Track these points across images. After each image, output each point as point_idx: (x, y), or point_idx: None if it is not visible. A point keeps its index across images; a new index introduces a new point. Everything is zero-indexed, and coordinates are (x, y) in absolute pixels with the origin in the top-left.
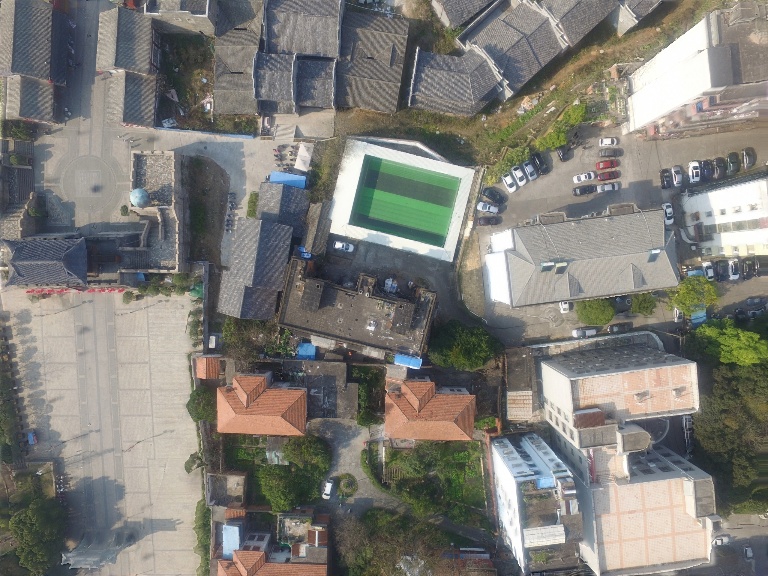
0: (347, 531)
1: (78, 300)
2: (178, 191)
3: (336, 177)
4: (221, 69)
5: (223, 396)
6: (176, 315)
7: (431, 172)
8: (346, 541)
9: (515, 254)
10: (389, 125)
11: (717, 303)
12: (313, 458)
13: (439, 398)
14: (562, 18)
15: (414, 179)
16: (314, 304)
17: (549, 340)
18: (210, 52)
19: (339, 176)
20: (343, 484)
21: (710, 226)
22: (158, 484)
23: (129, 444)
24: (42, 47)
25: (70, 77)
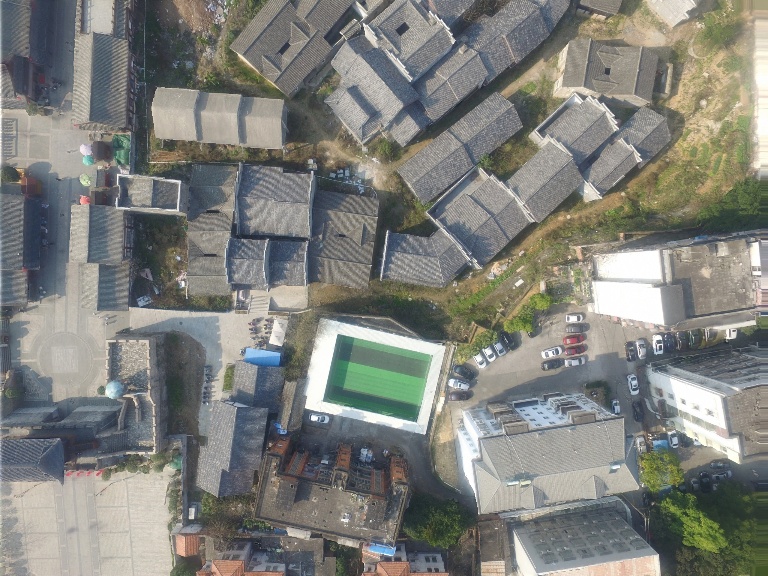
0: None
1: None
2: (154, 375)
3: (310, 352)
4: (194, 252)
5: None
6: (155, 486)
7: None
8: None
9: (482, 466)
10: (362, 294)
11: (682, 467)
12: None
13: None
14: (528, 200)
15: (387, 351)
16: (289, 503)
17: None
18: (183, 231)
19: (313, 354)
20: None
21: (672, 407)
22: None
23: None
24: (14, 239)
25: (44, 257)
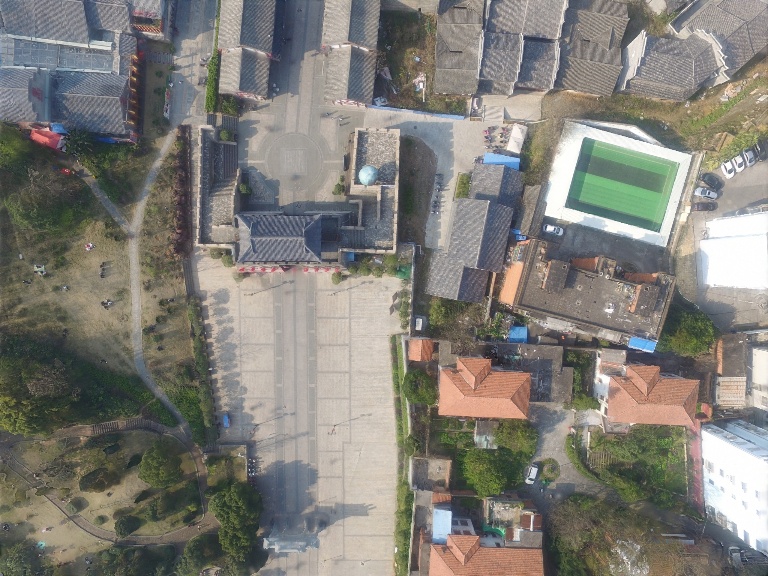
0: (563, 515)
1: (278, 280)
2: None
3: (549, 160)
4: (441, 47)
5: (448, 378)
6: (379, 297)
7: (644, 157)
8: (565, 525)
9: None
10: (596, 109)
11: None
12: (528, 442)
13: (664, 382)
14: None
15: (626, 163)
16: (560, 285)
17: (758, 327)
18: (424, 30)
19: (556, 159)
20: (547, 469)
21: None
22: (352, 468)
23: (324, 427)
24: (266, 20)
25: None
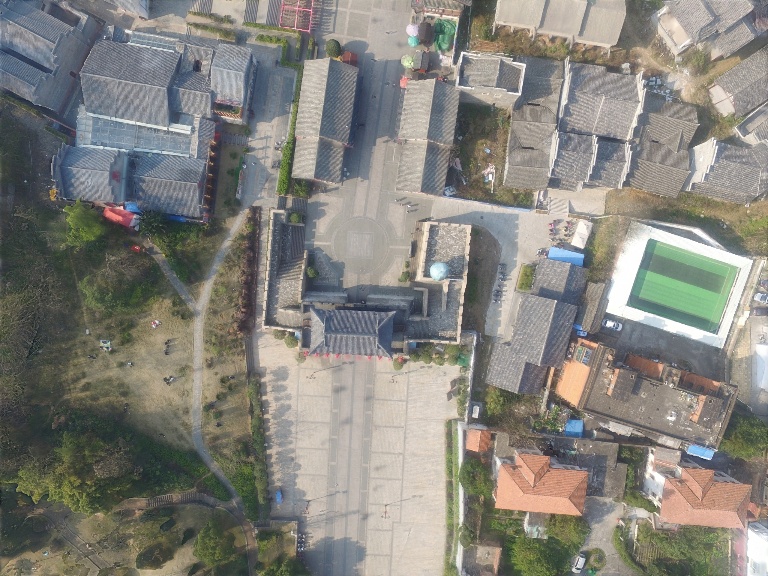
0: None
1: (338, 360)
2: None
3: (612, 257)
4: (514, 143)
5: (508, 474)
6: (437, 382)
7: (705, 258)
8: None
9: None
10: (658, 206)
11: None
12: None
13: (718, 486)
14: None
15: (686, 263)
16: (626, 394)
17: None
18: (496, 123)
19: (620, 257)
20: (594, 559)
21: None
22: (401, 548)
23: (375, 506)
24: (345, 111)
25: None
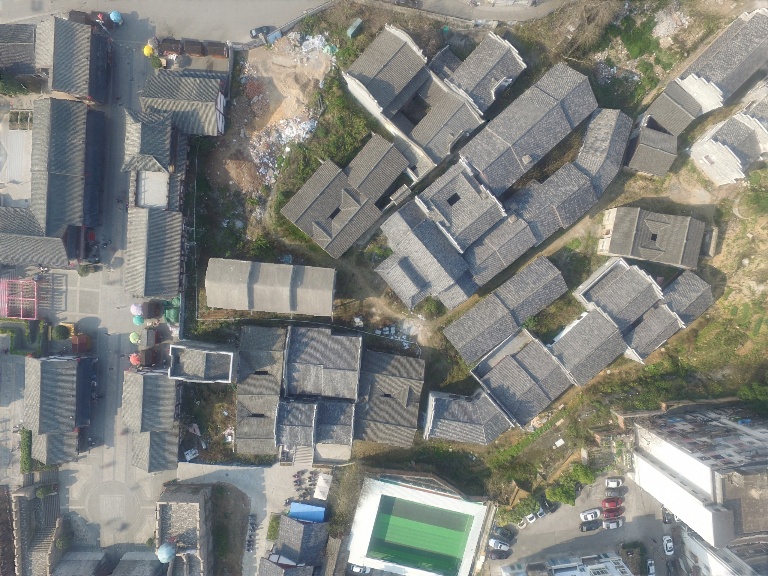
0: None
1: None
2: (202, 533)
3: (354, 506)
4: (243, 413)
5: None
6: None
7: None
8: None
9: None
10: None
11: None
12: None
13: None
14: (572, 370)
15: (428, 506)
16: None
17: None
18: (231, 387)
19: (357, 511)
20: None
21: None
22: None
23: None
24: (67, 403)
25: (93, 410)
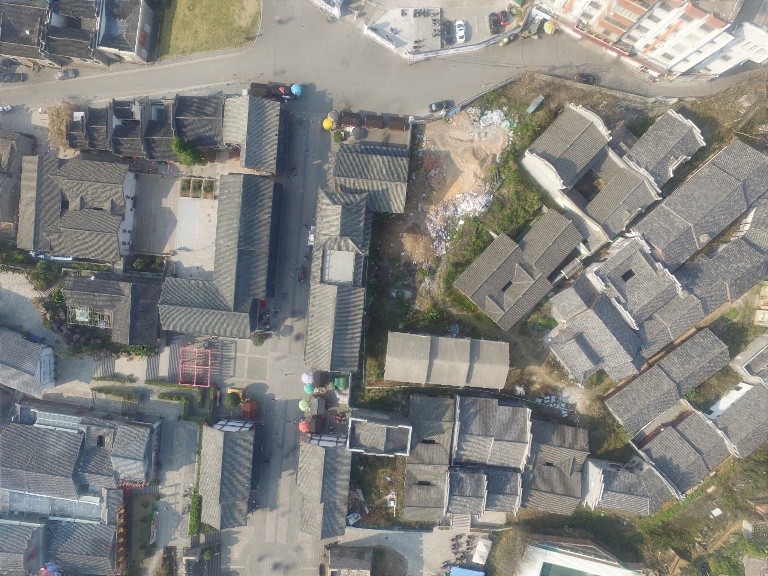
0: None
1: None
2: None
3: (512, 571)
4: (410, 481)
5: None
6: None
7: None
8: None
9: None
10: None
11: None
12: None
13: None
14: (739, 444)
15: None
16: None
17: None
18: None
19: None
20: None
21: None
22: None
23: None
24: (244, 472)
25: None
